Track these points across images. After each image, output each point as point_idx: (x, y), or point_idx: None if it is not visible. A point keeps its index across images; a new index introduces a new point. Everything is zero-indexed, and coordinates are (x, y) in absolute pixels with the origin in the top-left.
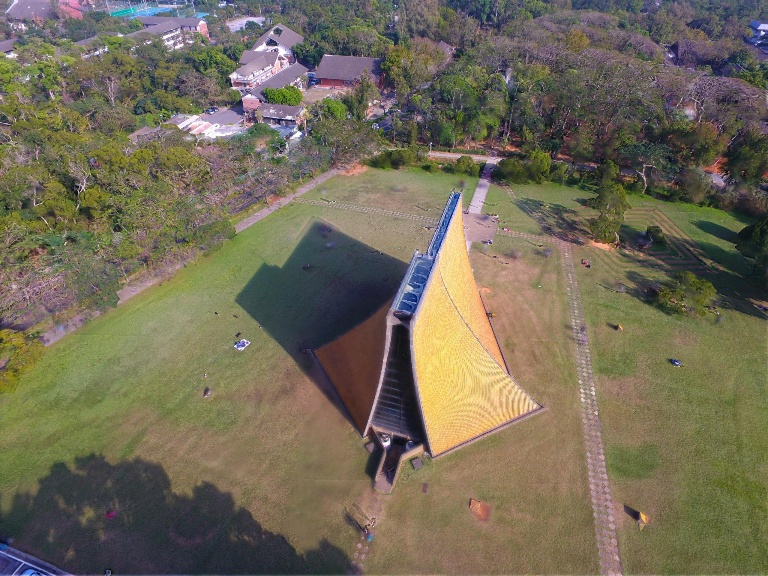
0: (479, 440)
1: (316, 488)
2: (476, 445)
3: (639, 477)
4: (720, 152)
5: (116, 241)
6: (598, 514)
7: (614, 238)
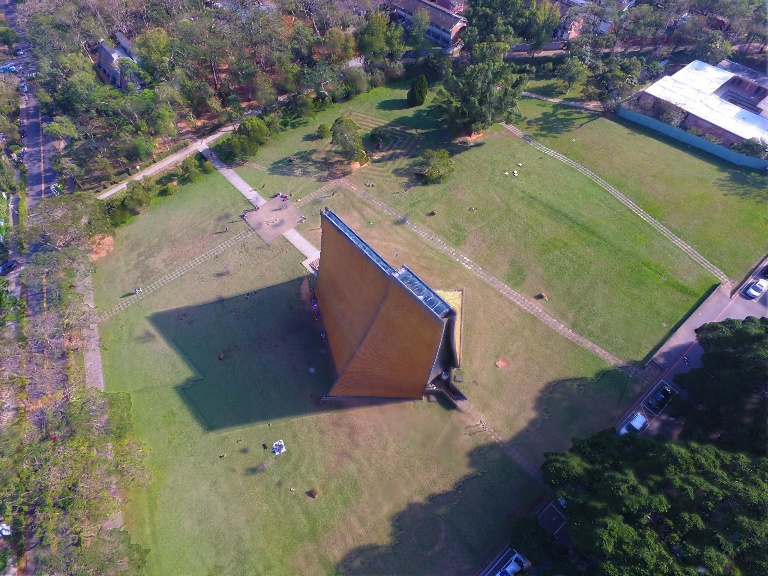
0: (463, 336)
1: (442, 446)
2: (465, 340)
3: (524, 280)
4: (353, 46)
5: (81, 514)
6: (532, 312)
7: (364, 154)
